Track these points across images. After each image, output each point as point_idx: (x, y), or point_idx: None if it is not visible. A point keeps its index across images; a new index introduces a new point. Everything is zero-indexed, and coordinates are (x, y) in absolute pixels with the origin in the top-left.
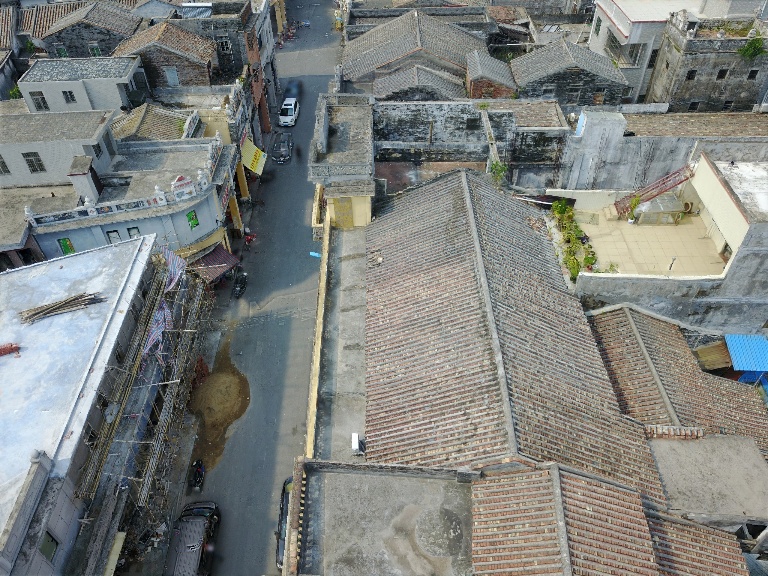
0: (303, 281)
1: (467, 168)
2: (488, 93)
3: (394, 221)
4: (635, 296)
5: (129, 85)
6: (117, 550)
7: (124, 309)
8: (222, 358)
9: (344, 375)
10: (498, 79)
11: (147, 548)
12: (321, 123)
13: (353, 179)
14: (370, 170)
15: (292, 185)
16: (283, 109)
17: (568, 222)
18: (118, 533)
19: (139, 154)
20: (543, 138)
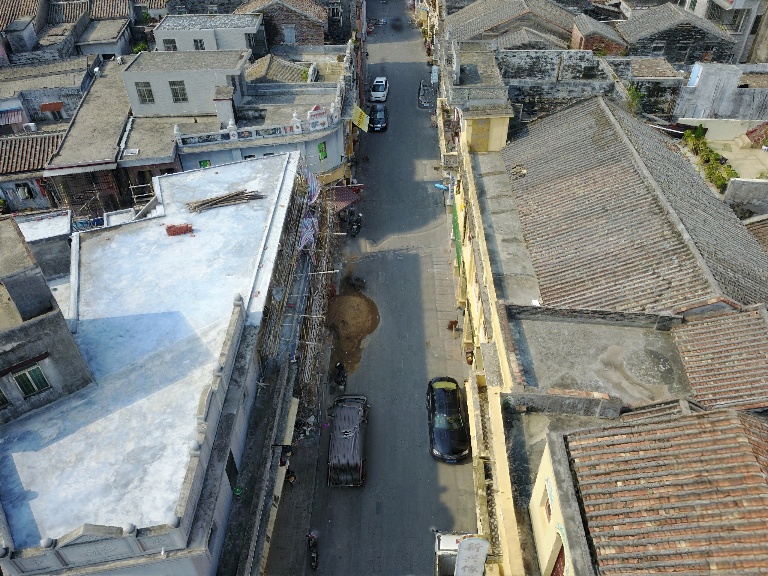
0: (415, 224)
1: None
2: (598, 50)
3: (532, 142)
4: None
5: (251, 40)
6: (294, 412)
7: (285, 204)
8: (346, 284)
9: (508, 261)
10: (609, 36)
11: (300, 435)
12: (457, 54)
13: (491, 103)
14: None
15: (391, 148)
16: (375, 85)
17: (704, 146)
18: (293, 398)
19: (267, 96)
20: (657, 88)
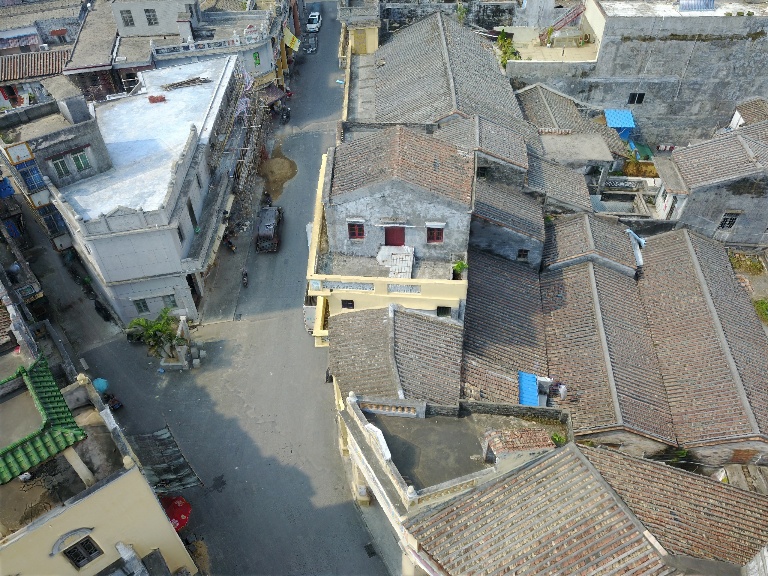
0: (330, 116)
1: (441, 10)
2: None
3: (393, 45)
4: (543, 77)
5: None
6: (231, 201)
7: (225, 85)
8: (277, 153)
9: (362, 112)
10: None
11: (240, 230)
12: None
13: (366, 19)
14: (378, 14)
15: (319, 66)
16: (310, 19)
17: None
18: (230, 194)
19: (216, 21)
20: (498, 10)
